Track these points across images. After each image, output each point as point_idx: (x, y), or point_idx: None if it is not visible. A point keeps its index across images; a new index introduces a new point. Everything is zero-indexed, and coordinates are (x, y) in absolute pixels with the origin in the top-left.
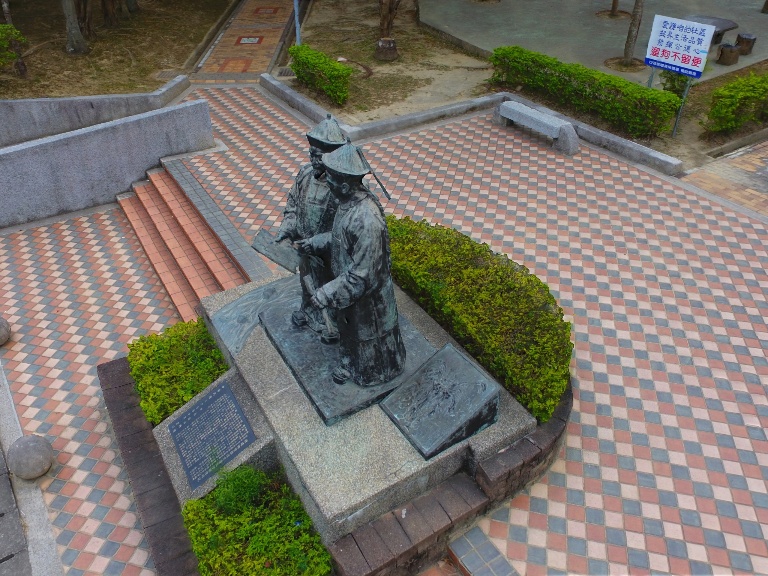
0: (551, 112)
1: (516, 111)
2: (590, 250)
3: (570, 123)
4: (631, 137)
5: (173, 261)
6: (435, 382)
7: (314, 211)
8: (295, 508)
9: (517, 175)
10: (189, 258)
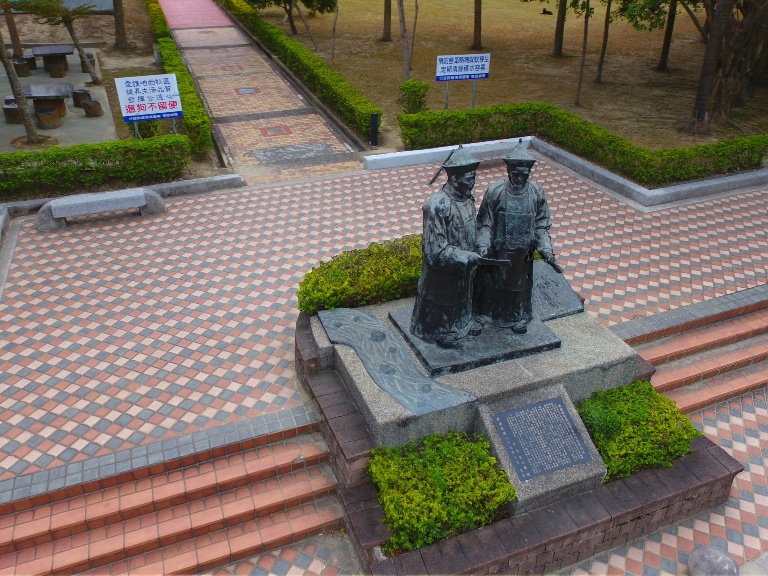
0: (84, 195)
1: (80, 204)
2: (325, 238)
3: (141, 188)
4: (168, 181)
5: (102, 568)
6: (536, 285)
7: (473, 225)
8: (603, 396)
9: (180, 241)
10: (134, 530)
